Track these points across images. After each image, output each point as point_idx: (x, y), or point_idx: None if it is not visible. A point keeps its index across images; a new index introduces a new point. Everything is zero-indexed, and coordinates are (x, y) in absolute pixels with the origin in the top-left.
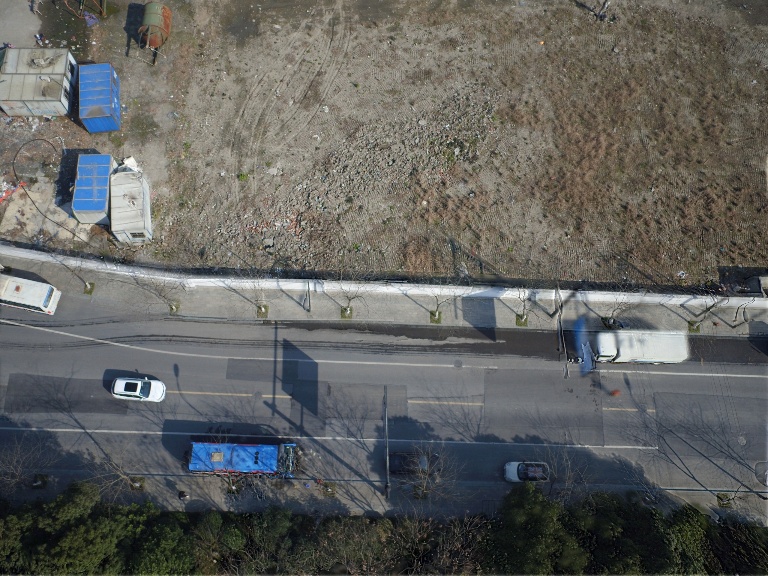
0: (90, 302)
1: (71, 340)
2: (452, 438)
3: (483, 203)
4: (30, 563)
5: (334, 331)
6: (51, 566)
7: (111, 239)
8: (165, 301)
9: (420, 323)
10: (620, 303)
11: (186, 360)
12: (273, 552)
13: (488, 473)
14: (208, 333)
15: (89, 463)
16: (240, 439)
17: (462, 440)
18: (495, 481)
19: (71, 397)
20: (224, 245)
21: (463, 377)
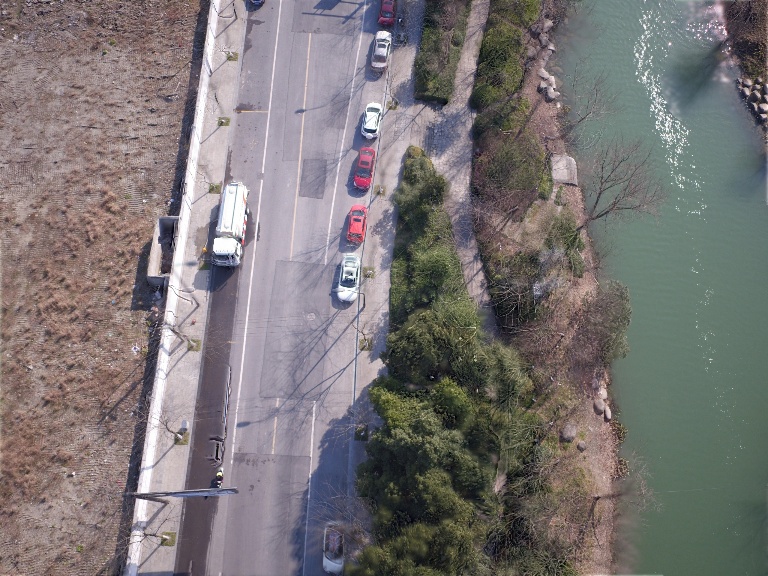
0: None
1: None
2: None
3: None
4: None
5: None
6: None
7: None
8: None
9: None
10: (160, 422)
11: None
12: None
13: None
14: None
15: None
16: None
17: None
18: None
19: None
20: None
21: None
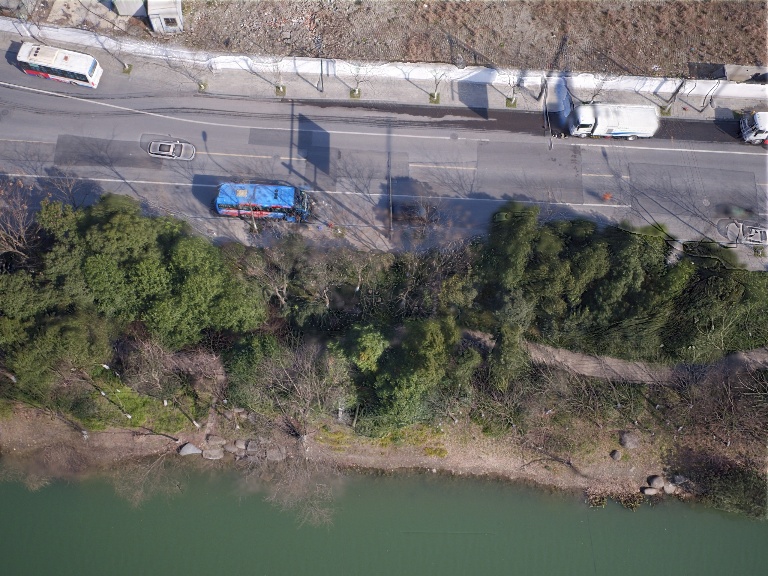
0: (128, 80)
1: (112, 110)
2: (448, 195)
3: (478, 7)
4: (85, 236)
5: (344, 108)
6: (103, 238)
7: (146, 29)
8: (194, 81)
9: (421, 103)
10: (599, 90)
11: (213, 128)
12: (290, 270)
13: (480, 223)
14: (232, 107)
15: (129, 199)
16: (261, 182)
17: (457, 197)
18: (486, 224)
19: (112, 154)
20: (247, 36)
21: (458, 147)
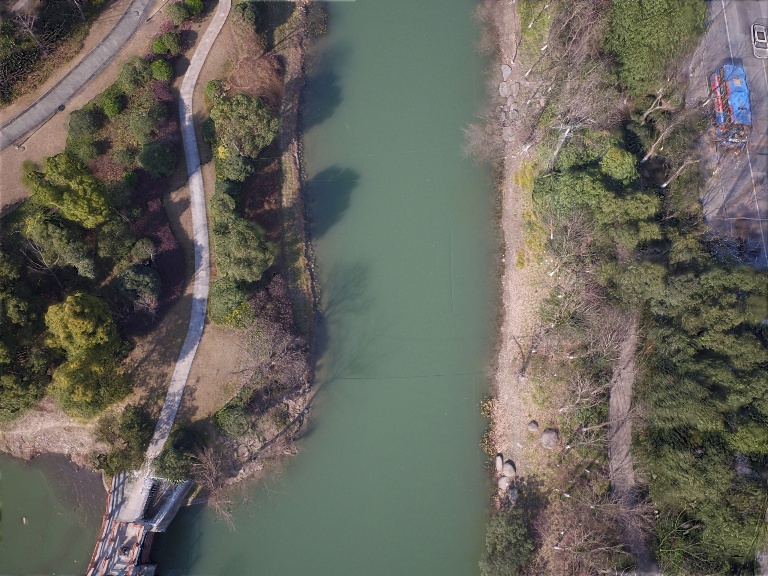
0: None
1: None
2: None
3: None
4: None
5: None
6: None
7: None
8: None
9: None
10: None
11: None
12: None
13: None
14: None
15: (711, 6)
16: None
17: None
18: None
19: None
20: None
21: None
